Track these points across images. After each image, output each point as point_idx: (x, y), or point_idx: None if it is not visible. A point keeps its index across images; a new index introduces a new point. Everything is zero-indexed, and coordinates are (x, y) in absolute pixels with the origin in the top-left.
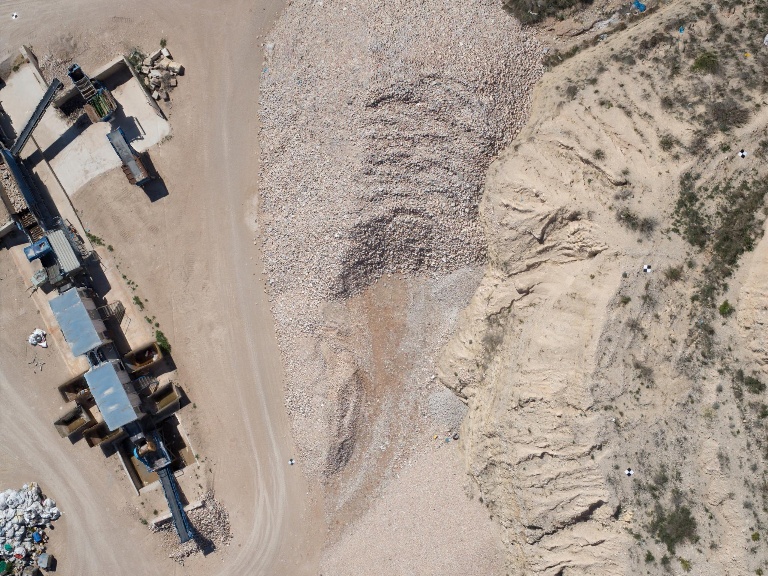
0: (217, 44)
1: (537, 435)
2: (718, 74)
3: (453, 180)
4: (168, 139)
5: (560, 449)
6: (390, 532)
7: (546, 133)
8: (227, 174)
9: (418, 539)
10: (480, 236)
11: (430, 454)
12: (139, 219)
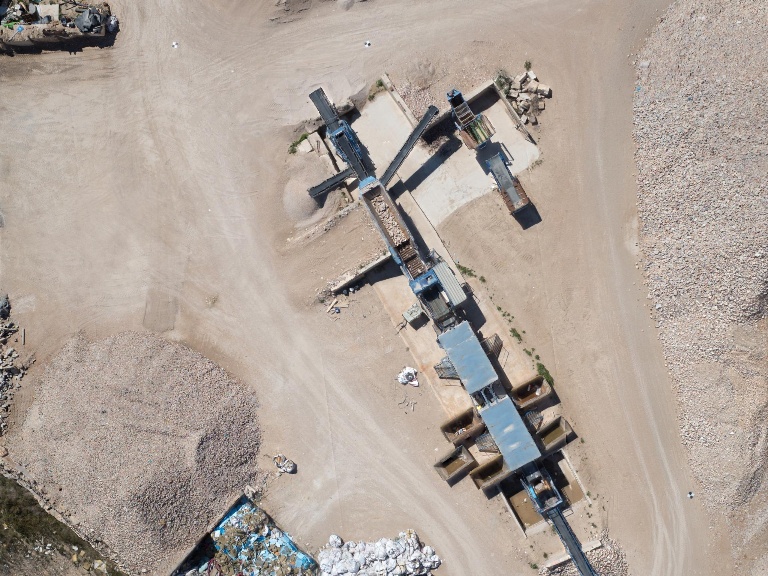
0: (585, 64)
1: None
2: None
3: None
4: (538, 164)
5: None
6: None
7: None
8: (603, 197)
9: None
10: None
11: None
12: (511, 248)
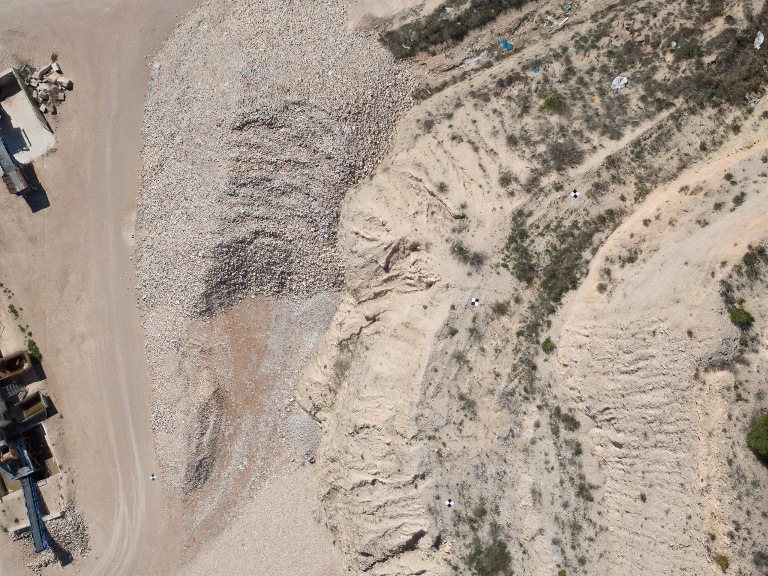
0: (106, 61)
1: (368, 462)
2: (564, 115)
3: (313, 206)
4: (53, 152)
5: (388, 477)
6: (242, 552)
7: (400, 164)
8: (108, 189)
9: (266, 561)
10: (338, 262)
11: (286, 476)
12: (19, 229)
